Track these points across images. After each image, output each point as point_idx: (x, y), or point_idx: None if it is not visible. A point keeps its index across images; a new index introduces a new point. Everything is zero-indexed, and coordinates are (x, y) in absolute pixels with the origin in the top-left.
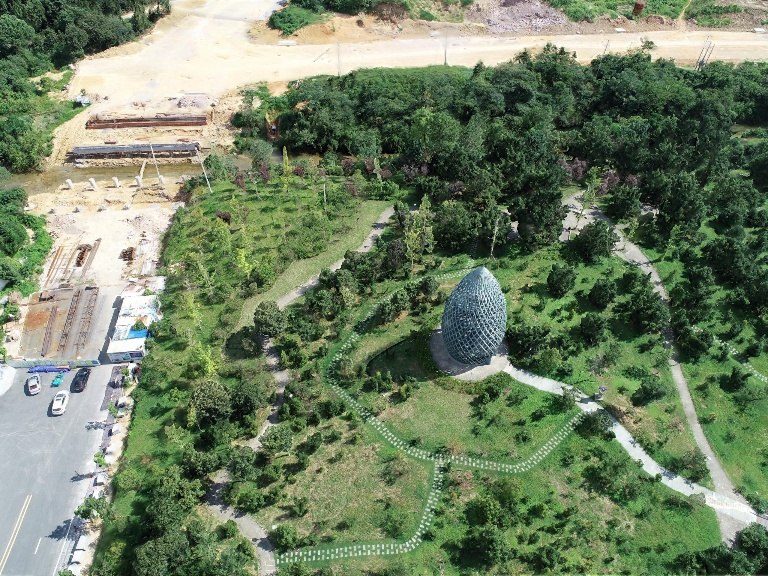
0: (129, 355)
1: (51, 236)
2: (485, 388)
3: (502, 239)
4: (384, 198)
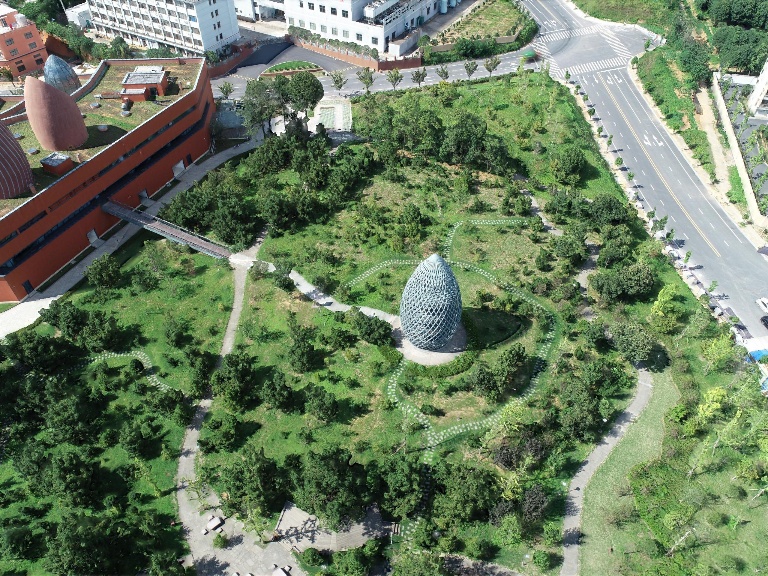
0: None
1: None
2: None
3: None
4: None
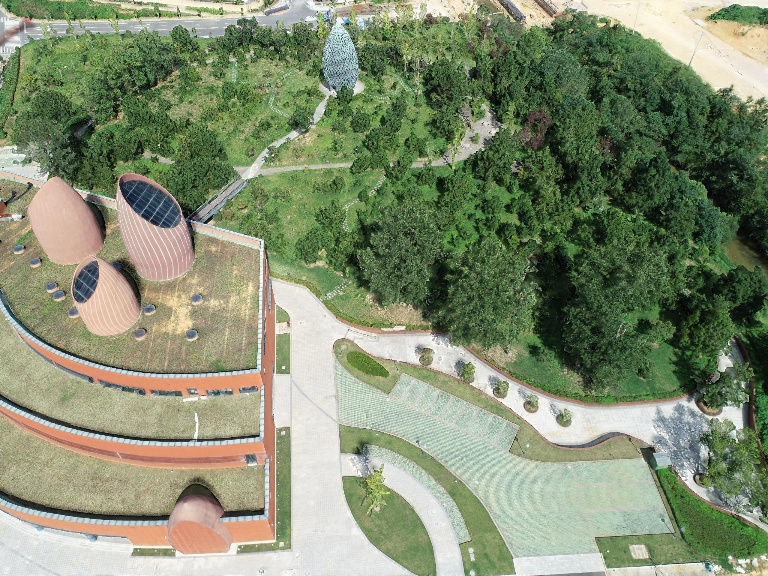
0: None
1: None
2: None
3: None
4: None
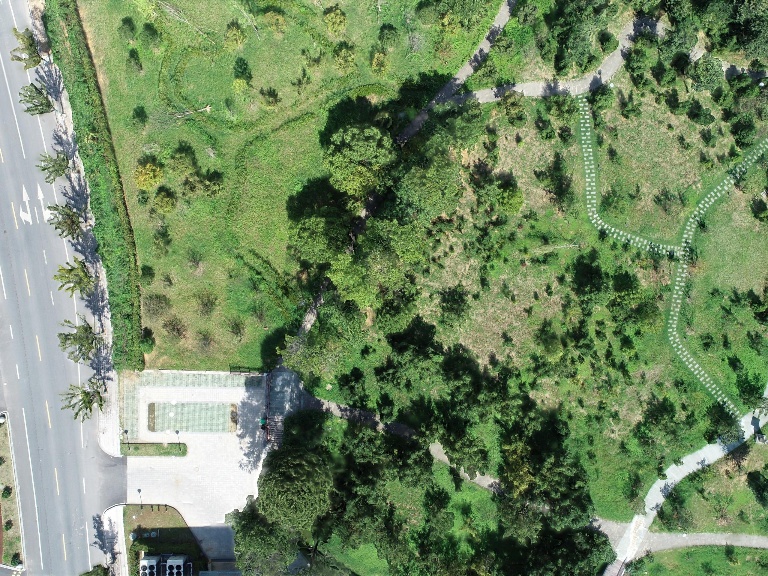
0: None
1: None
2: None
3: None
4: None
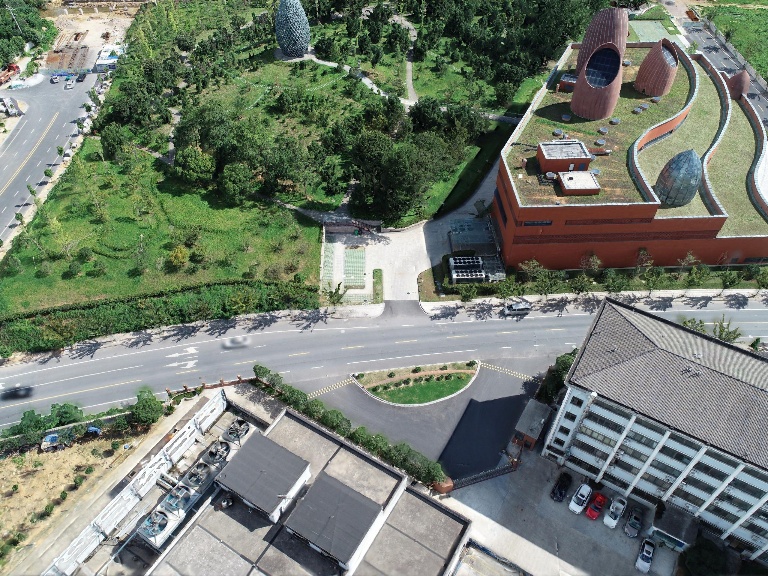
0: (108, 67)
1: (57, 29)
2: None
3: (325, 12)
4: (265, 6)
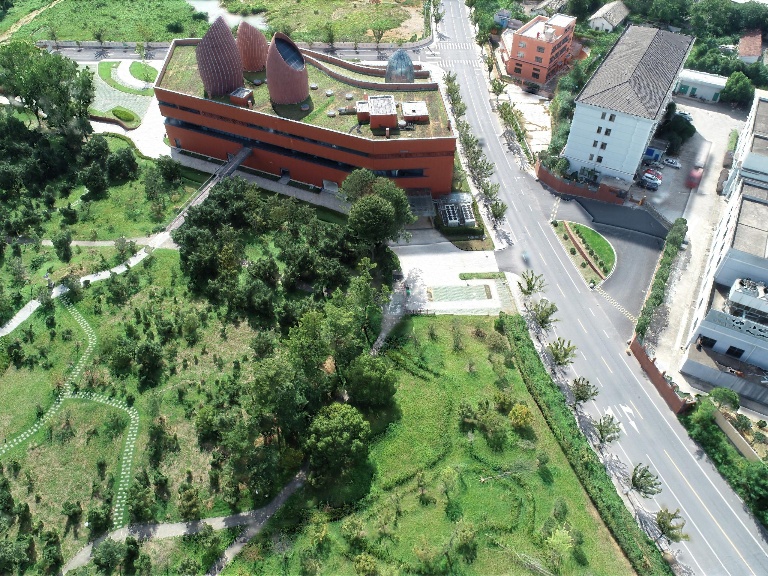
0: None
1: None
2: (7, 354)
3: None
4: None
